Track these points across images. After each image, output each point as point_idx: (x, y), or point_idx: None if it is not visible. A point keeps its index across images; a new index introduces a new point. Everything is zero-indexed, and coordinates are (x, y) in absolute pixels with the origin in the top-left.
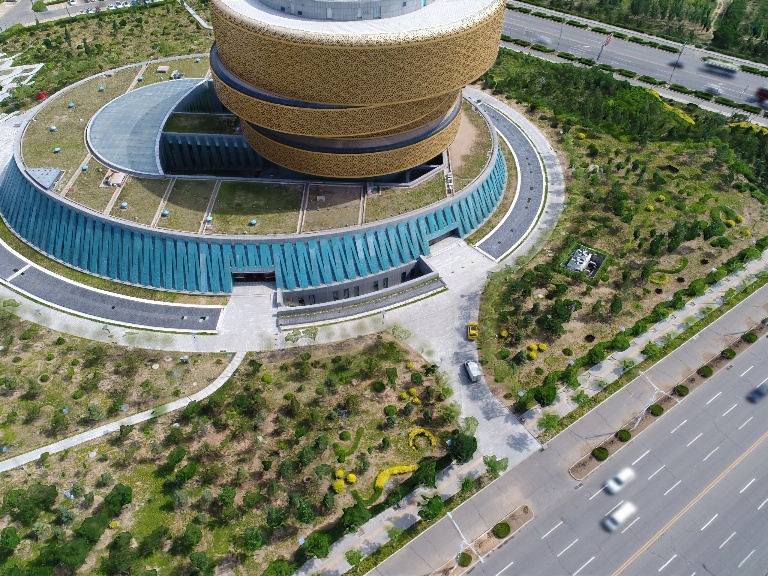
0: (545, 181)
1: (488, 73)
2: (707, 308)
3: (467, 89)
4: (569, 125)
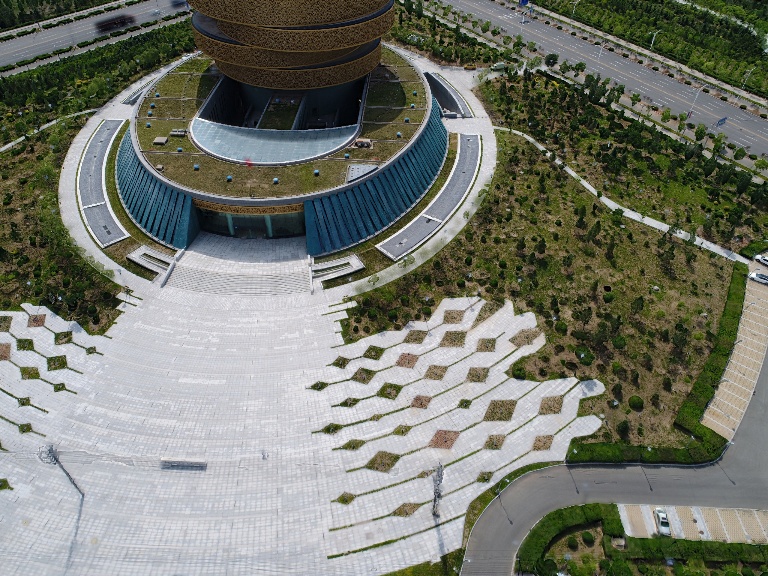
0: None
1: None
2: (458, 14)
3: None
4: None
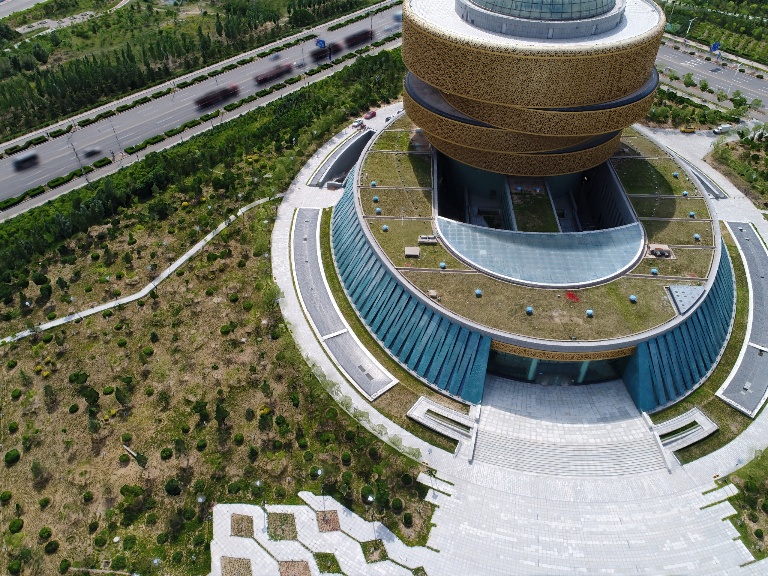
0: None
1: (357, 99)
2: None
3: (378, 113)
4: None
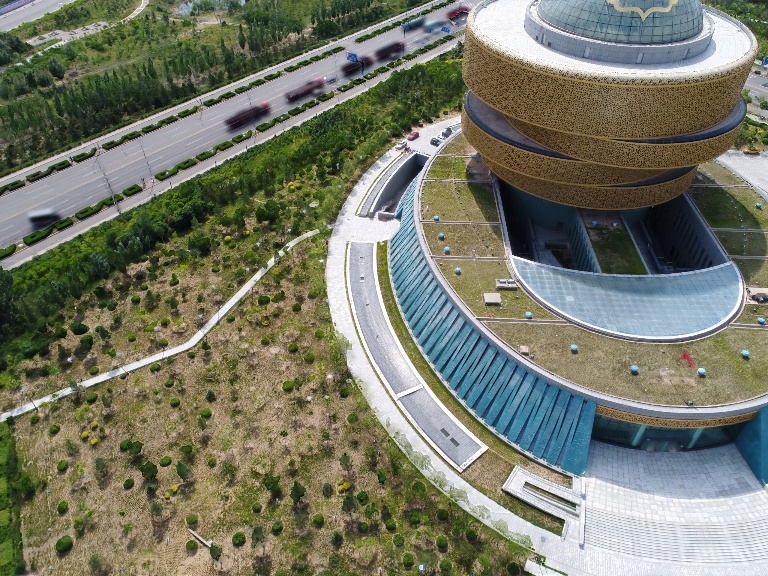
0: None
1: None
2: None
3: (421, 134)
4: None
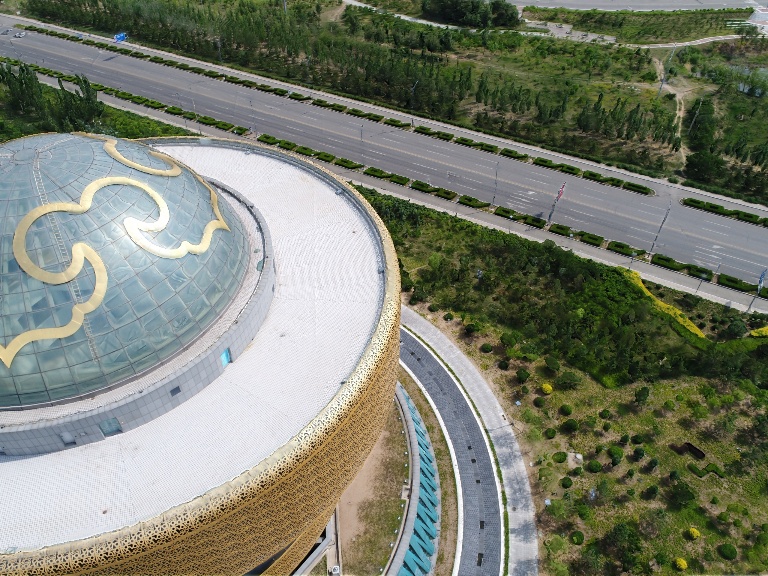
0: (502, 502)
1: (401, 264)
2: None
3: None
4: (525, 361)
